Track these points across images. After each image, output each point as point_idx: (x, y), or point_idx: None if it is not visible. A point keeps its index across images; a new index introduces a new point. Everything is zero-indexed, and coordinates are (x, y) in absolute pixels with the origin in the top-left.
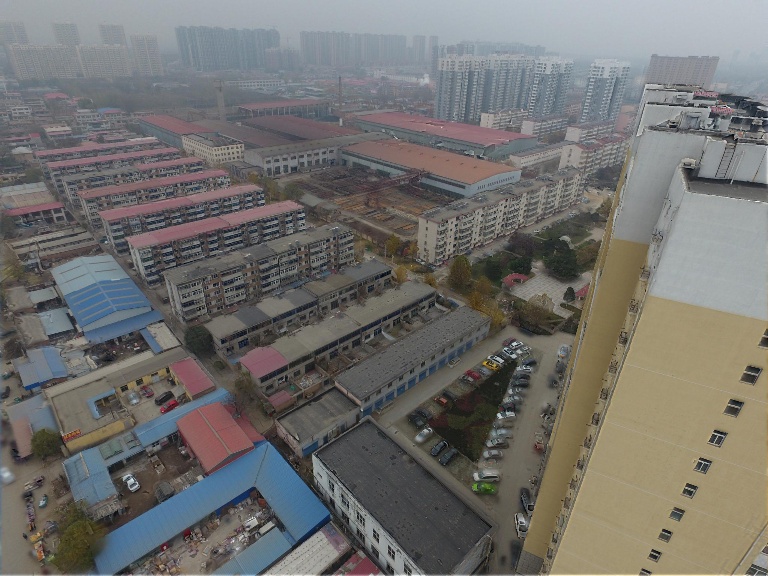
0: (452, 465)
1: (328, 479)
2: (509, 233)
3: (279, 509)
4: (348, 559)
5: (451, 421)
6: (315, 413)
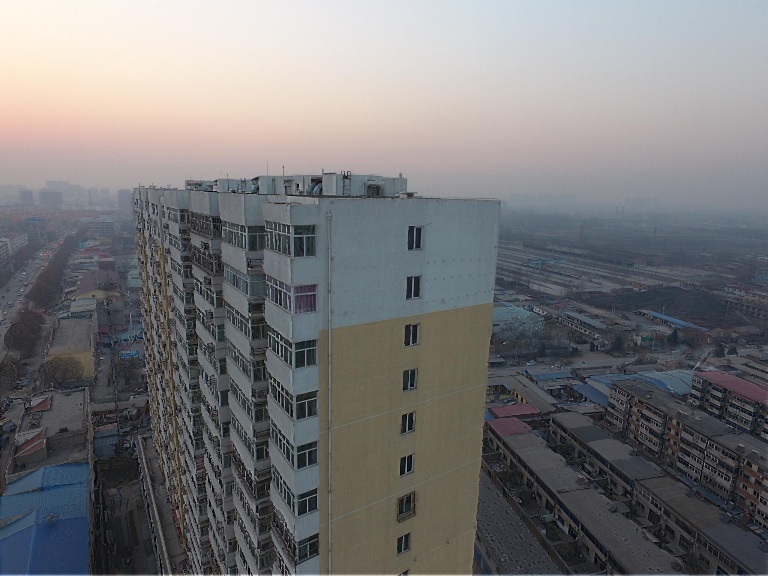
0: None
1: None
2: None
3: None
4: None
5: None
6: None
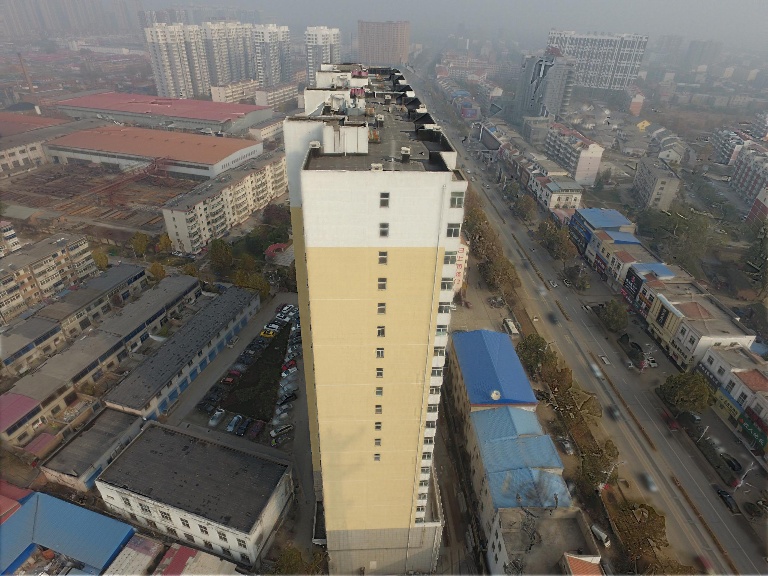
0: (249, 433)
1: (120, 496)
2: (263, 207)
3: (71, 550)
4: (163, 557)
5: (240, 395)
6: (90, 441)
